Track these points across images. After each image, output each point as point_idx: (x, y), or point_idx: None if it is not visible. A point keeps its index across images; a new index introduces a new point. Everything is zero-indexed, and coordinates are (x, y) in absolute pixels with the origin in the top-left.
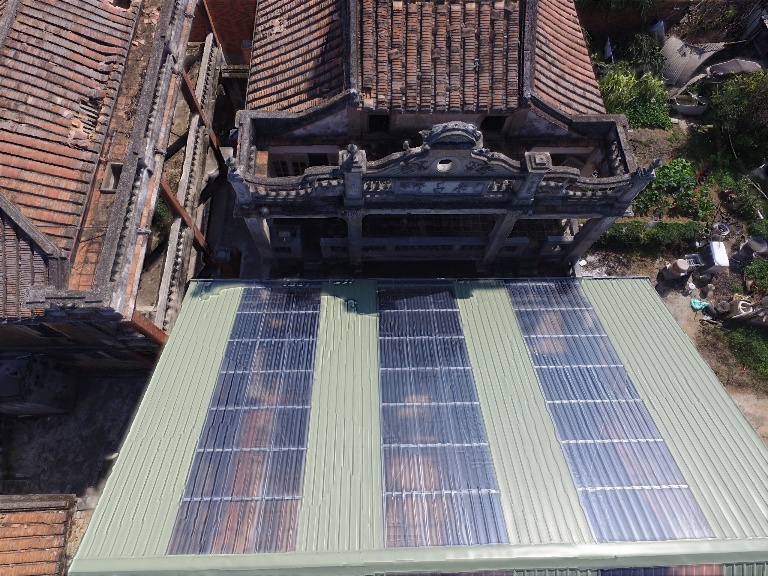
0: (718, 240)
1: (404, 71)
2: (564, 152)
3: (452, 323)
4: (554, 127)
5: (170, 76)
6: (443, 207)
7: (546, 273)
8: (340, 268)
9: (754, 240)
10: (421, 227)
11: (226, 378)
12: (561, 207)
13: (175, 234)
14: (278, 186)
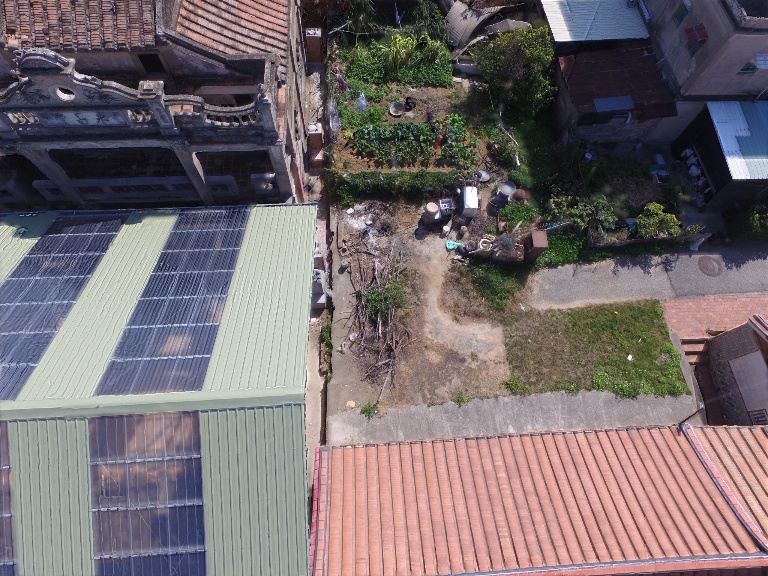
0: (471, 185)
1: (46, 13)
2: (243, 92)
3: (104, 243)
4: (211, 66)
5: None
6: (97, 139)
7: None
8: None
9: (507, 184)
10: (148, 172)
11: None
12: (217, 138)
13: None
14: None
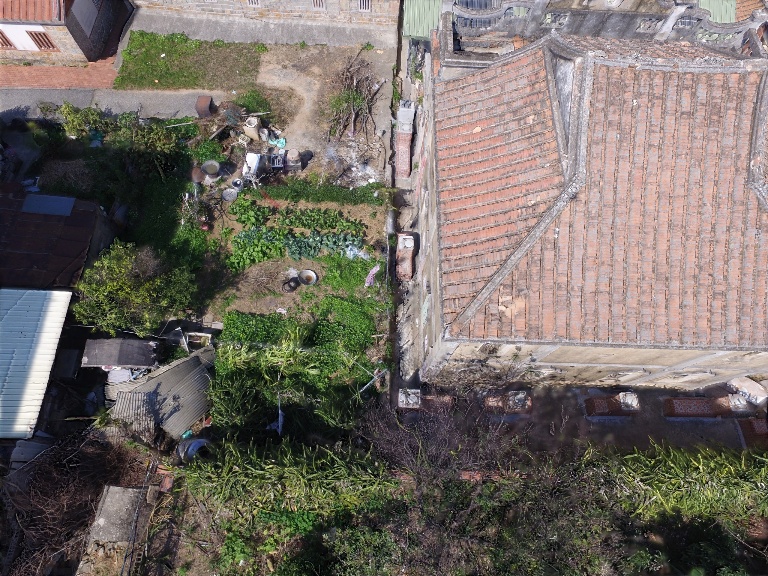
0: None
1: None
2: None
3: None
4: None
5: None
6: None
7: None
8: None
9: None
10: None
11: None
12: None
13: None
14: None
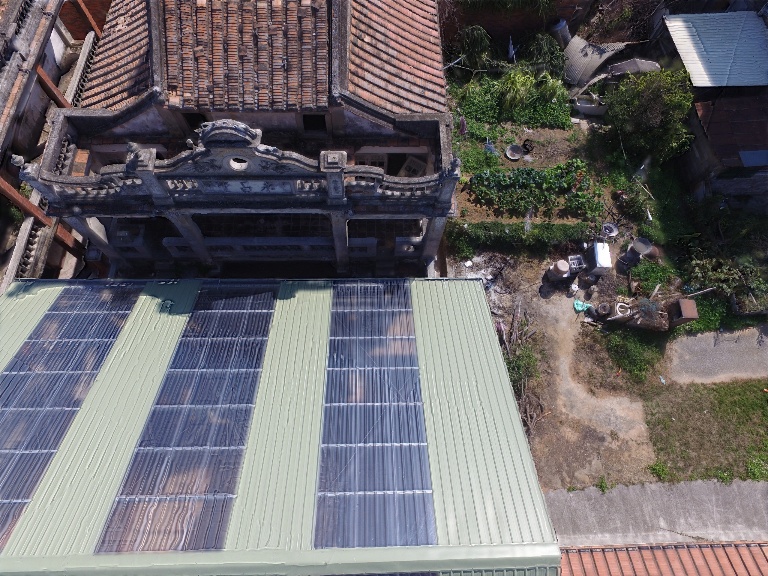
0: (603, 241)
1: (211, 69)
2: (401, 151)
3: (262, 324)
4: (378, 126)
5: (16, 74)
6: (256, 207)
7: (406, 274)
8: (195, 268)
9: (640, 241)
10: (277, 227)
11: (6, 379)
12: (383, 207)
13: (24, 233)
14: (79, 185)
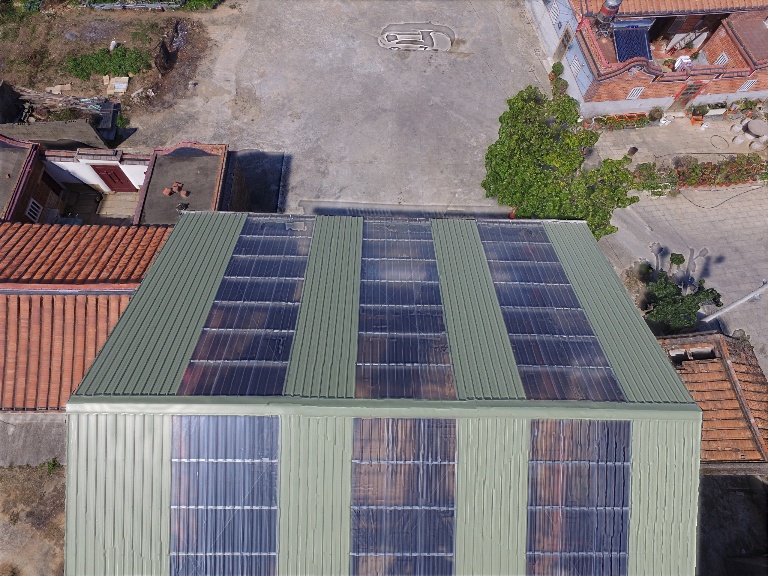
0: None
1: None
2: None
3: None
4: None
5: None
6: None
7: None
8: None
9: None
10: None
11: None
12: None
13: None
14: None
